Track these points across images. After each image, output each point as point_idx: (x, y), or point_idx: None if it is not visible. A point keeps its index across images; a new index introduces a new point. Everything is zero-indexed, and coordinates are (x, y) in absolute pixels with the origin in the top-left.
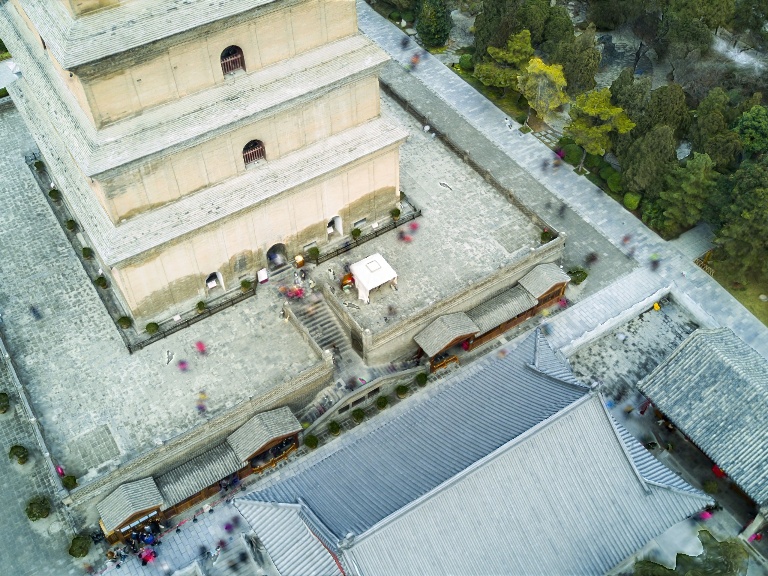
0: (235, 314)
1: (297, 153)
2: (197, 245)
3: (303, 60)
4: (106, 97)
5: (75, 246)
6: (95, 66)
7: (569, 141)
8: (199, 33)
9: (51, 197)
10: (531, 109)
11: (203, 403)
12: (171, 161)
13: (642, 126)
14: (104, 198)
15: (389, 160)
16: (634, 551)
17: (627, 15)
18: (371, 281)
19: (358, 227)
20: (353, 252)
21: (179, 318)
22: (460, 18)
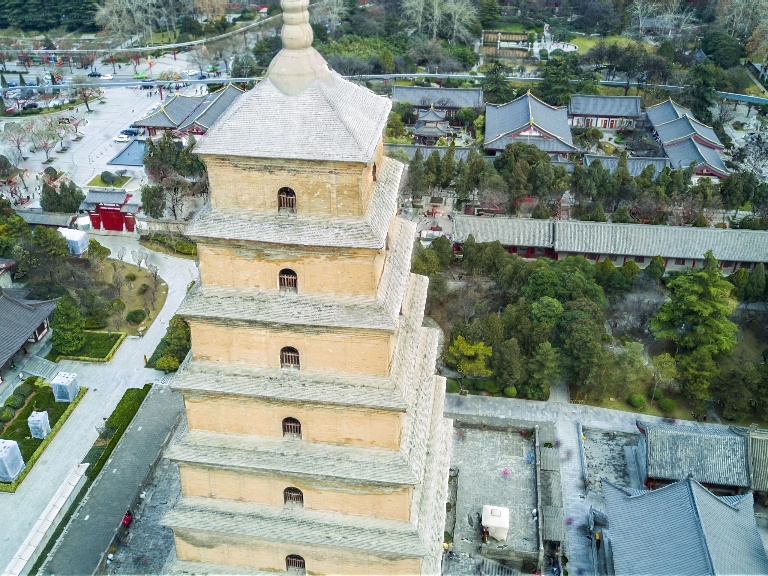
0: None
1: None
2: None
3: None
4: None
5: None
6: None
7: None
8: None
9: None
10: None
11: None
12: None
13: None
14: (417, 570)
15: None
16: (761, 541)
17: None
18: (505, 522)
19: None
20: (458, 519)
21: None
22: None
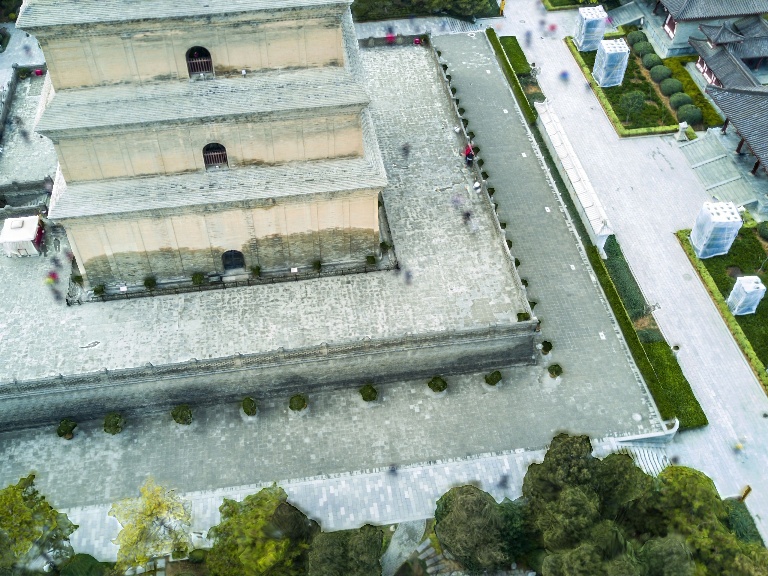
0: None
1: None
2: None
3: None
4: None
5: None
6: None
7: (96, 570)
8: None
9: None
10: None
11: (25, 132)
12: None
13: None
14: None
15: None
16: None
17: None
18: None
19: None
20: None
21: None
22: None
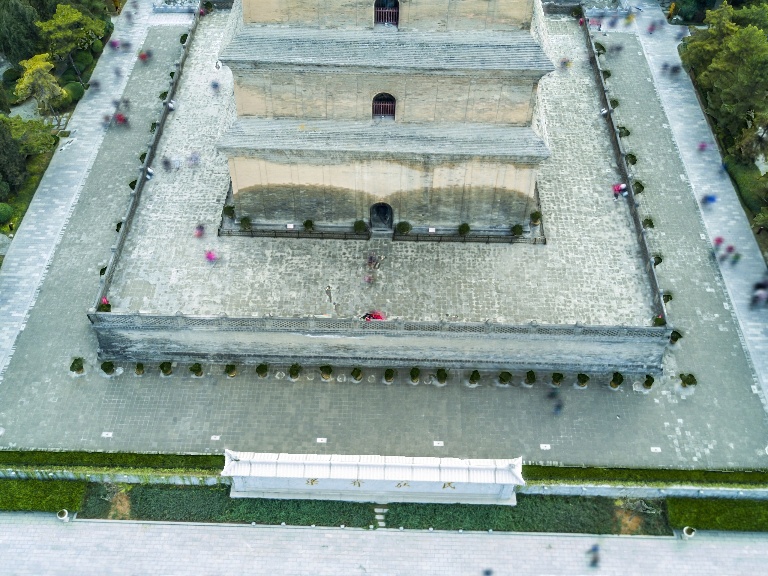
0: None
1: None
2: None
3: None
4: None
5: None
6: None
7: None
8: None
9: None
10: None
11: None
12: None
13: None
14: None
15: None
16: None
17: None
18: None
19: None
20: None
21: None
22: None
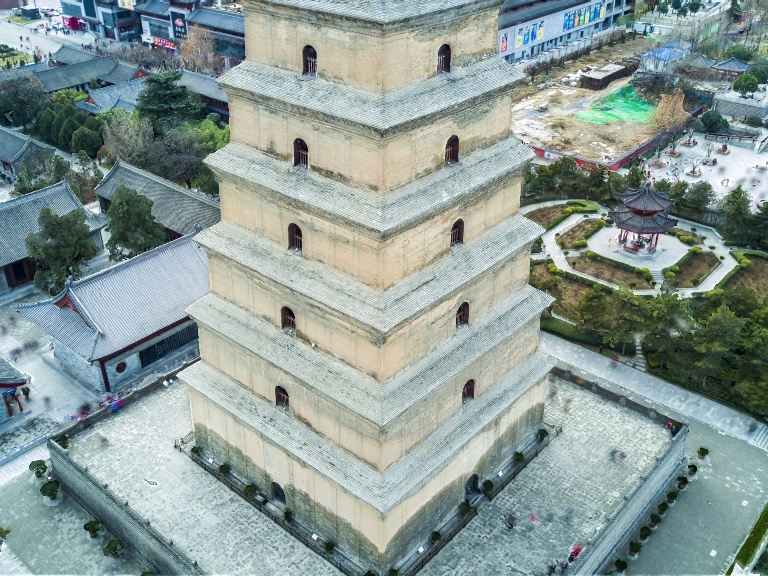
0: None
1: None
2: None
3: None
4: None
5: None
6: None
7: None
8: None
9: None
10: None
11: None
12: None
13: None
14: None
15: None
16: None
17: None
18: None
19: None
20: None
21: None
22: None
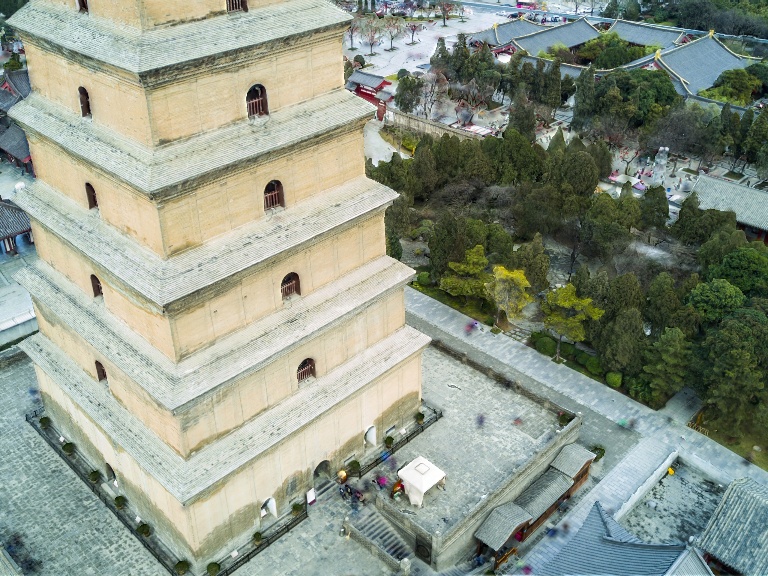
0: (293, 540)
1: (340, 368)
2: (257, 471)
3: (346, 281)
4: (187, 330)
5: (104, 497)
6: (183, 301)
7: (541, 335)
8: (267, 263)
9: (65, 451)
10: (495, 312)
11: None
12: (239, 387)
13: (607, 313)
14: (178, 431)
15: (414, 366)
16: None
17: (550, 226)
18: (424, 483)
19: (389, 435)
20: (390, 460)
21: (237, 554)
22: (404, 243)
